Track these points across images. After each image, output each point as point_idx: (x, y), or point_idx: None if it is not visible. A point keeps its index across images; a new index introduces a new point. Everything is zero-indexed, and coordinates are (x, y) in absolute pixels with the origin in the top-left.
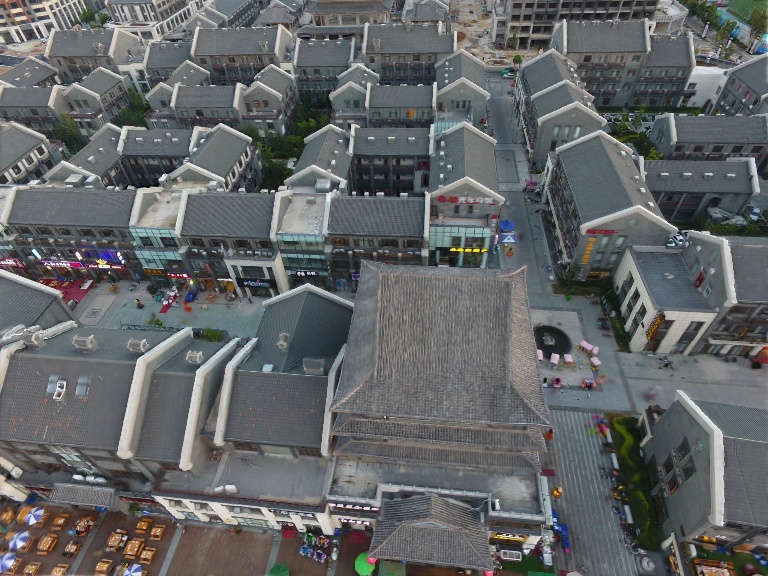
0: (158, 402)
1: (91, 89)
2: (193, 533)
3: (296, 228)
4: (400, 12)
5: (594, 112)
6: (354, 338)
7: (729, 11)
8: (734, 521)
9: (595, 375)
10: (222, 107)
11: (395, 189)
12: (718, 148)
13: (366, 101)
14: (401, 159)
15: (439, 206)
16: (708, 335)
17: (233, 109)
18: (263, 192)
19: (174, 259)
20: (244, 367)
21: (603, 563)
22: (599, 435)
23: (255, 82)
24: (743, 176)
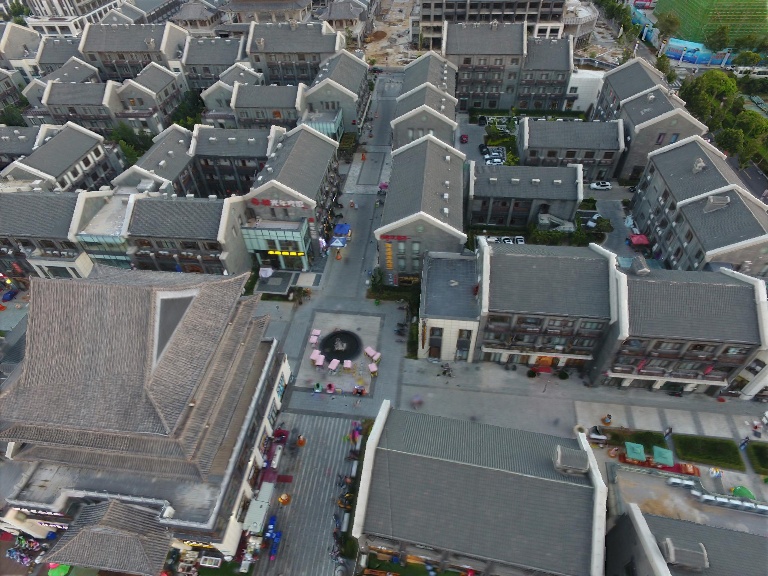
0: None
1: None
2: None
3: (100, 229)
4: (323, 10)
5: (443, 115)
6: None
7: (654, 14)
8: (373, 533)
9: (372, 381)
10: (93, 104)
11: (245, 190)
12: (571, 153)
13: (231, 101)
14: (246, 160)
15: (255, 209)
16: (480, 343)
17: (103, 107)
18: (77, 192)
19: None
20: None
21: (302, 571)
22: (350, 442)
23: (126, 80)
24: (570, 183)
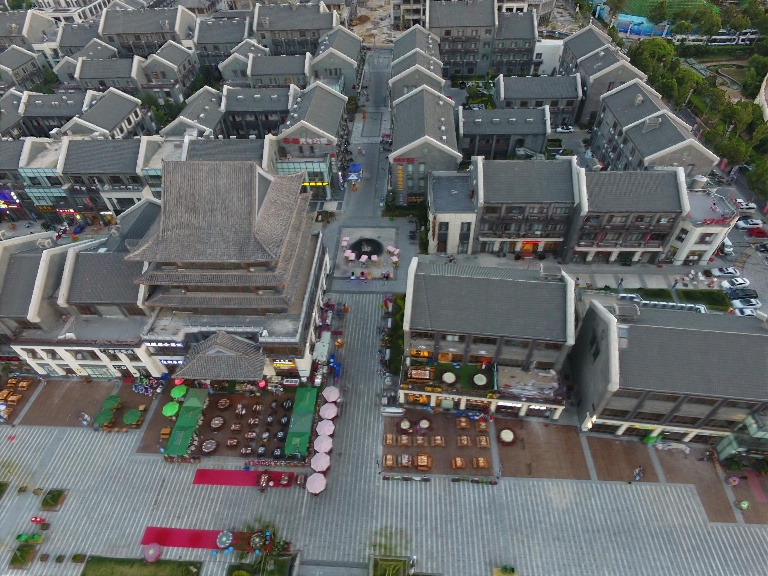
0: (14, 276)
1: (3, 64)
2: (53, 384)
3: (160, 165)
4: None
5: (433, 73)
6: (159, 219)
7: None
8: (417, 328)
9: (395, 270)
10: (122, 77)
11: None
12: (539, 103)
13: (248, 69)
14: (268, 115)
15: (286, 147)
16: (478, 234)
17: (132, 79)
18: (136, 138)
19: (60, 195)
20: (85, 251)
21: (360, 384)
22: (383, 308)
23: (151, 55)
24: (540, 120)
